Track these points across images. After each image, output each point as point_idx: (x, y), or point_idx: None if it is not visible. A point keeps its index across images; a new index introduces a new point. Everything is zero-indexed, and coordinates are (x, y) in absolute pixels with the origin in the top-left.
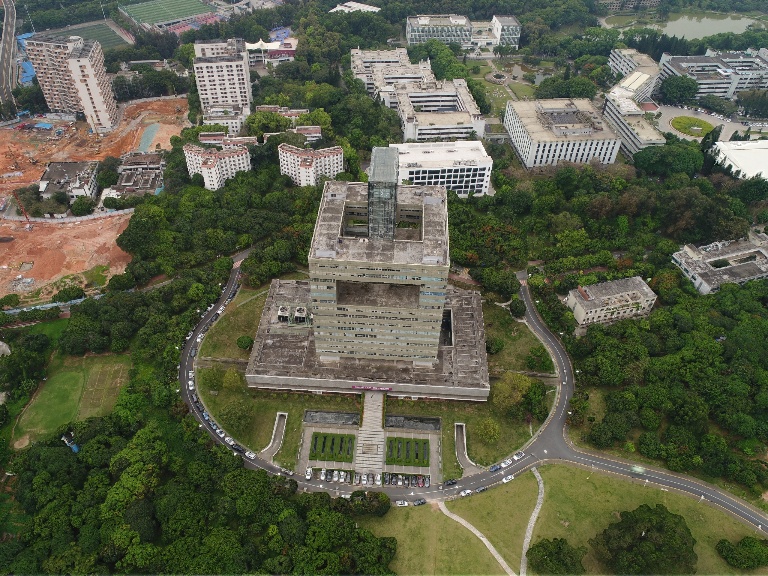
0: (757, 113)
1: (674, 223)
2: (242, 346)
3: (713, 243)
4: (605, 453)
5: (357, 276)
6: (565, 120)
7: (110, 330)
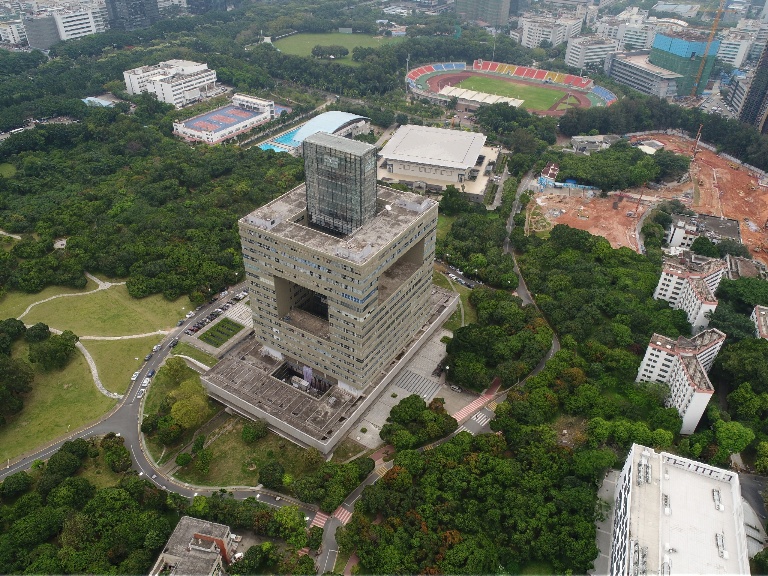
0: None
1: None
2: None
3: None
4: None
5: None
6: None
7: None
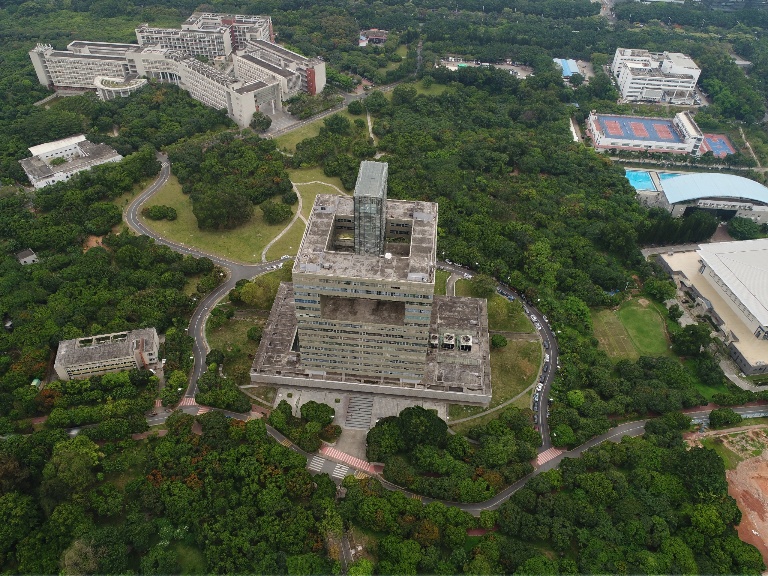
0: None
1: None
2: None
3: None
4: None
5: None
6: None
7: None
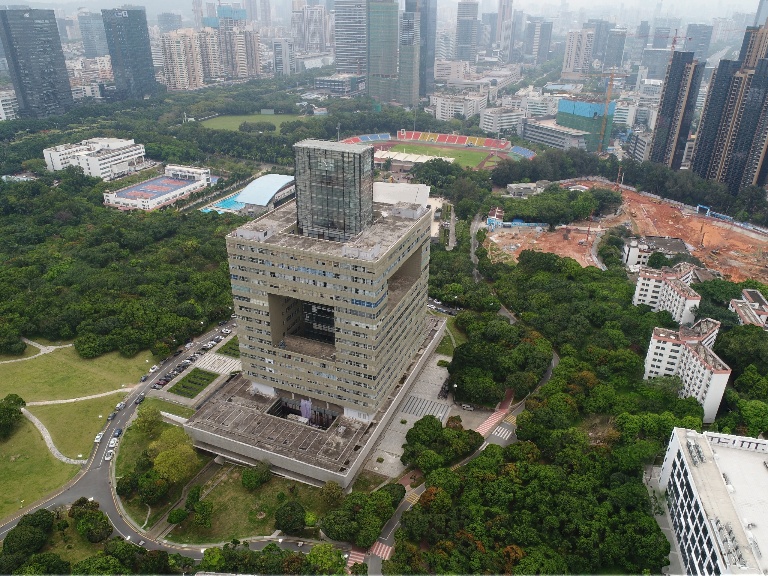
0: None
1: None
2: None
3: None
4: None
5: None
6: None
7: None
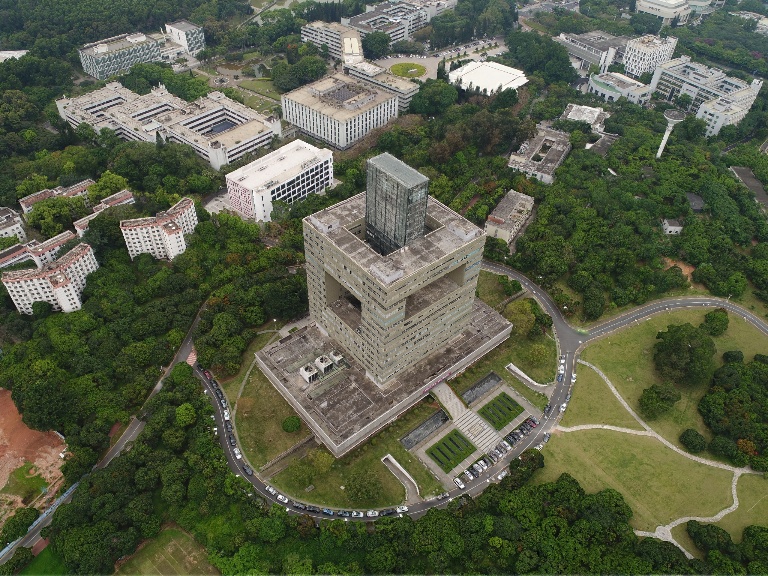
0: (438, 45)
1: (487, 143)
2: (295, 429)
3: (521, 146)
4: (601, 320)
5: (422, 283)
6: (345, 95)
7: (129, 518)
